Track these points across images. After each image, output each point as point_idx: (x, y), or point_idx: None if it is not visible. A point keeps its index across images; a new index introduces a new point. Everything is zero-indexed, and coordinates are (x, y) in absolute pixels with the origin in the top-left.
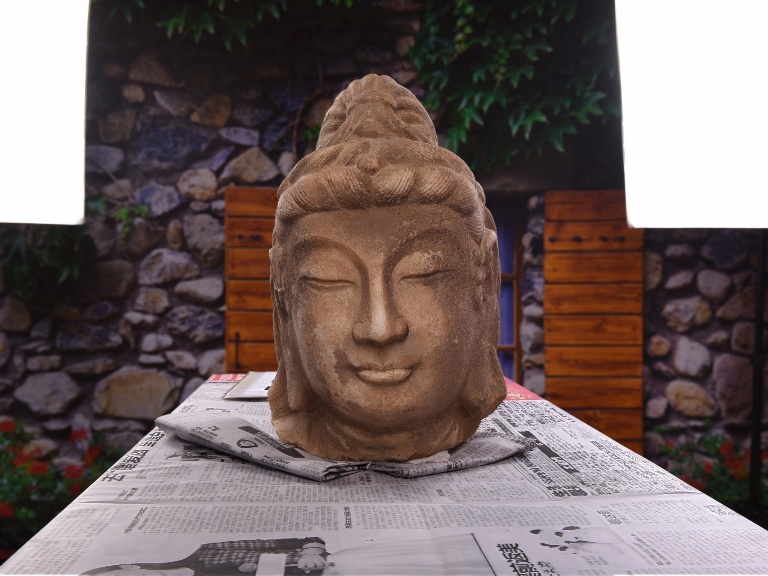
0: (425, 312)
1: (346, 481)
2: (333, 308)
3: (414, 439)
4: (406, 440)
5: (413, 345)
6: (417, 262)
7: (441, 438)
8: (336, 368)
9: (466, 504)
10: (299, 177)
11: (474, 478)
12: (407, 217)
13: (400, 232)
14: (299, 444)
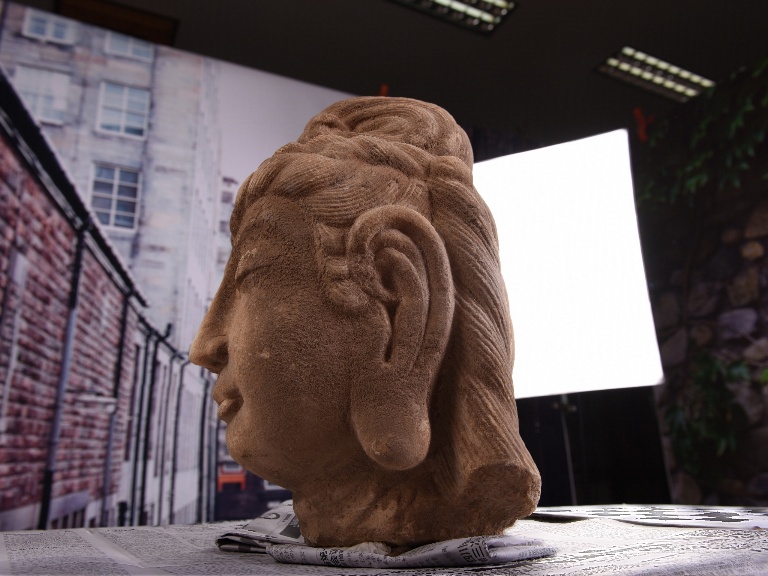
0: None
1: None
2: None
3: (314, 511)
4: (307, 512)
5: None
6: None
7: (352, 516)
8: None
9: None
10: None
11: (301, 569)
12: None
13: None
14: None
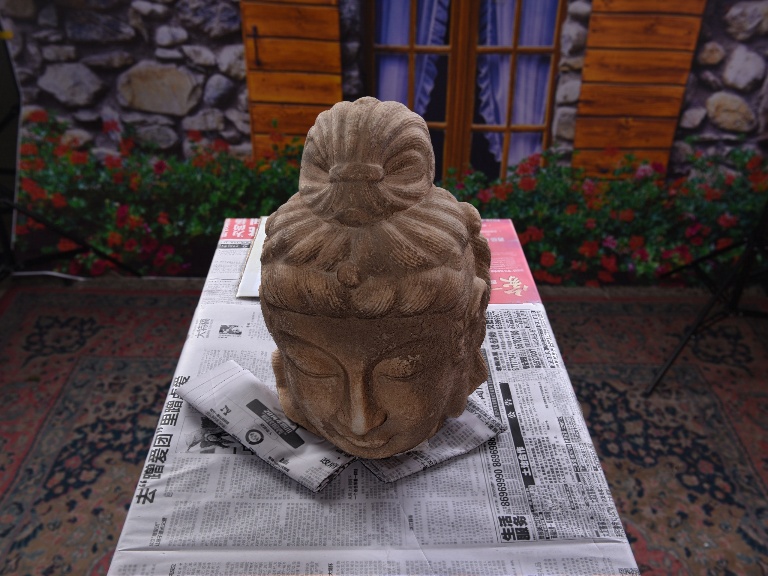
0: (403, 403)
1: (337, 489)
2: (318, 392)
3: None
4: None
5: (391, 425)
6: (396, 368)
7: None
8: (324, 428)
9: (427, 554)
10: (280, 259)
11: (444, 487)
12: (387, 331)
13: (379, 345)
14: (300, 424)
